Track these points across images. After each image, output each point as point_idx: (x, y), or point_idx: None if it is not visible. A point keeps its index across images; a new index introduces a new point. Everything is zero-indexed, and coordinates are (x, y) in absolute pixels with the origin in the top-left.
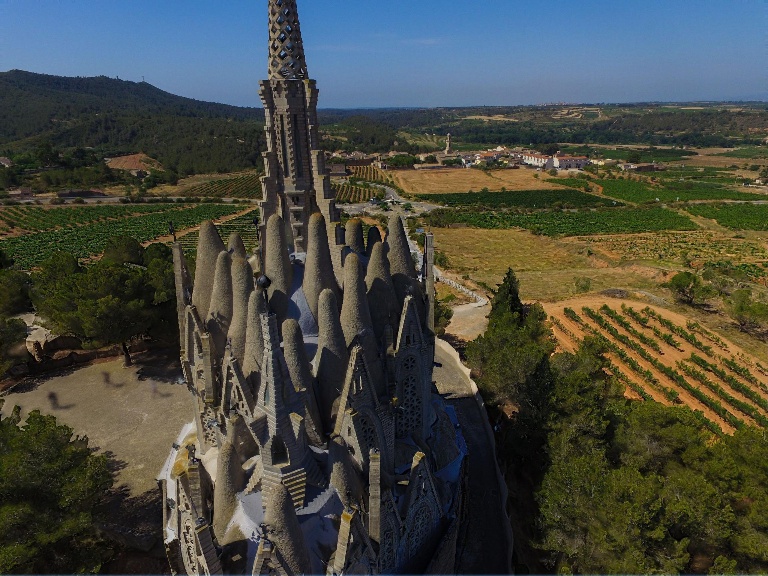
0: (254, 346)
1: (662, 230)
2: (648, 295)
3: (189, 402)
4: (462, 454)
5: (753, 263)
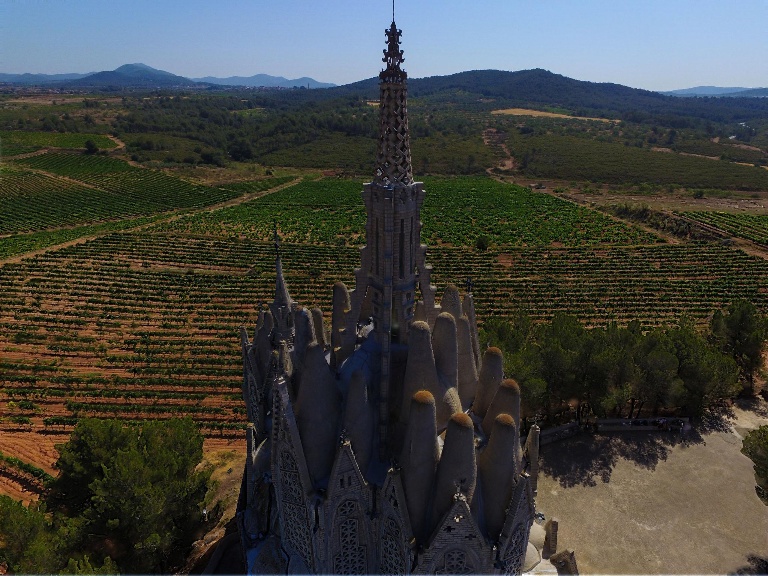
0: None
1: None
2: None
3: (653, 569)
4: (250, 575)
5: None
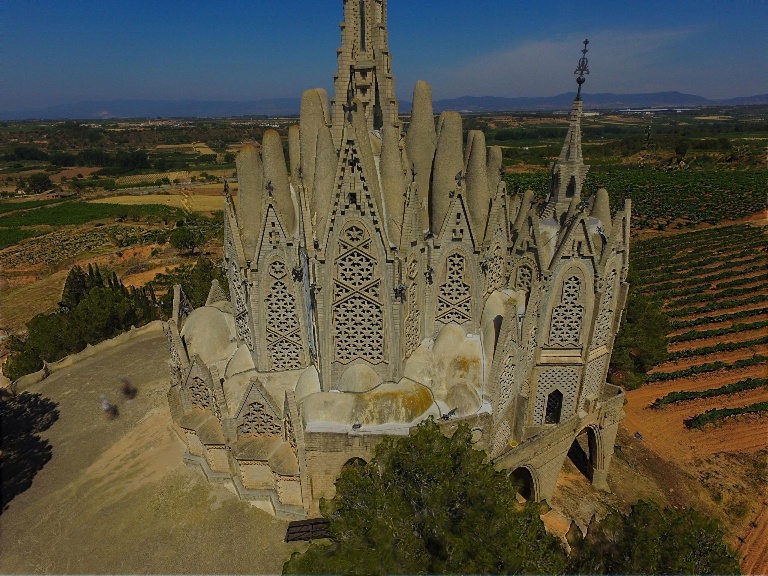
0: (487, 177)
1: (21, 241)
2: (163, 260)
3: None
4: None
5: (147, 233)
